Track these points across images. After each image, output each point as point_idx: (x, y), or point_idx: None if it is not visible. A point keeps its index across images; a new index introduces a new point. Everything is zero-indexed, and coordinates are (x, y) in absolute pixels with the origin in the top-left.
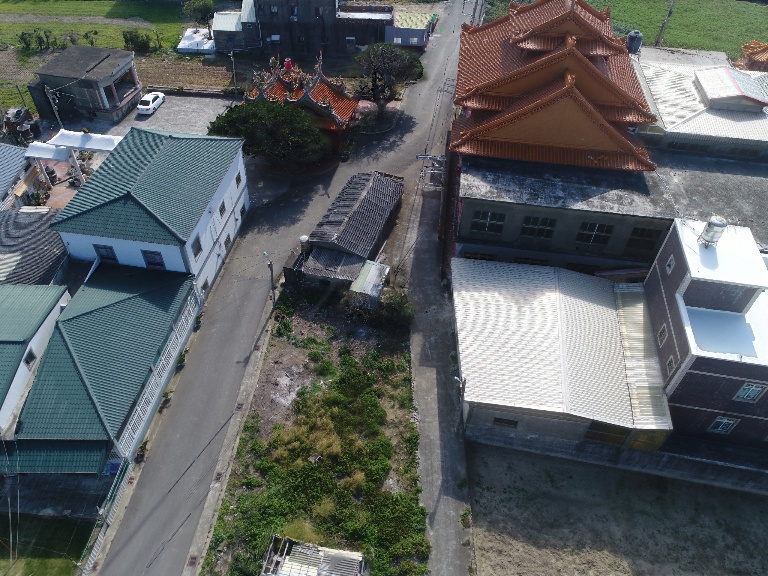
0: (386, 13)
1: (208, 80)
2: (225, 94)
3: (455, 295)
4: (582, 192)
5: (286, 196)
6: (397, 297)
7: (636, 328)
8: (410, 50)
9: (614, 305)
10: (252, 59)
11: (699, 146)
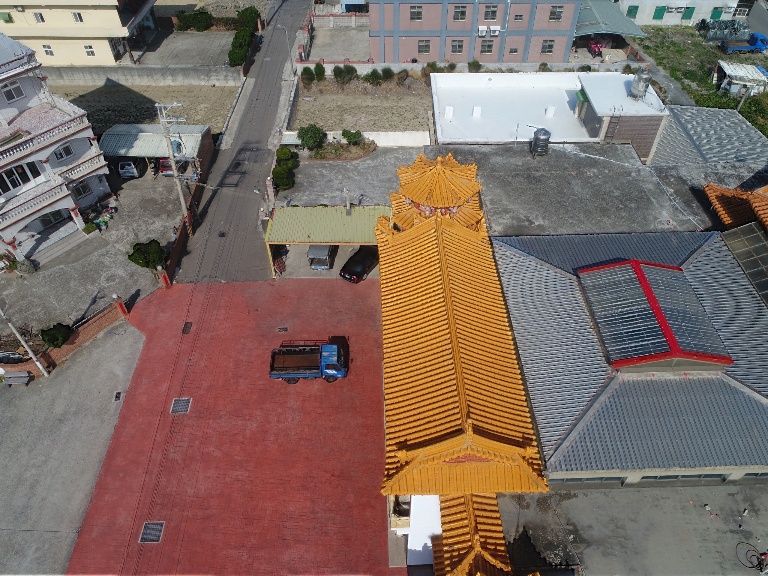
0: None
1: None
2: None
3: None
4: (767, 182)
5: None
6: None
7: None
8: None
9: None
10: None
11: None
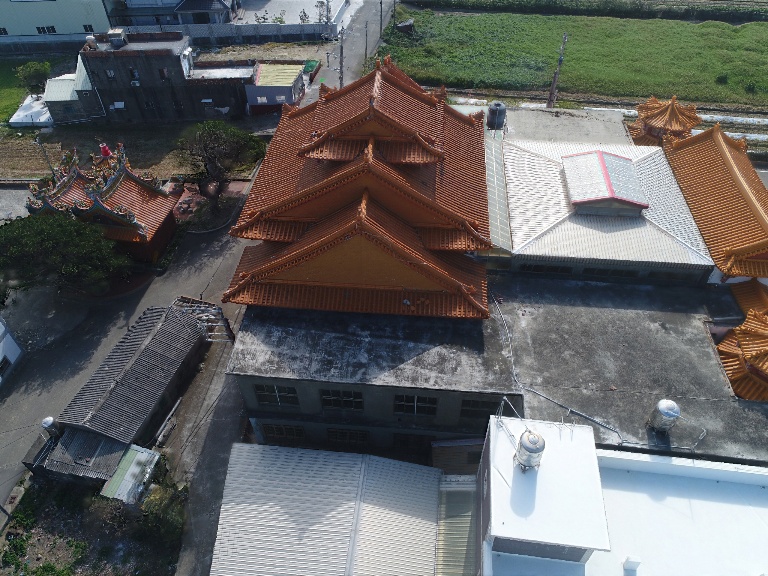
0: (249, 67)
1: (35, 163)
2: (45, 184)
3: (222, 510)
4: (393, 353)
5: (77, 331)
6: (164, 499)
7: (456, 558)
8: (279, 109)
9: (435, 514)
10: (95, 130)
11: (560, 267)
